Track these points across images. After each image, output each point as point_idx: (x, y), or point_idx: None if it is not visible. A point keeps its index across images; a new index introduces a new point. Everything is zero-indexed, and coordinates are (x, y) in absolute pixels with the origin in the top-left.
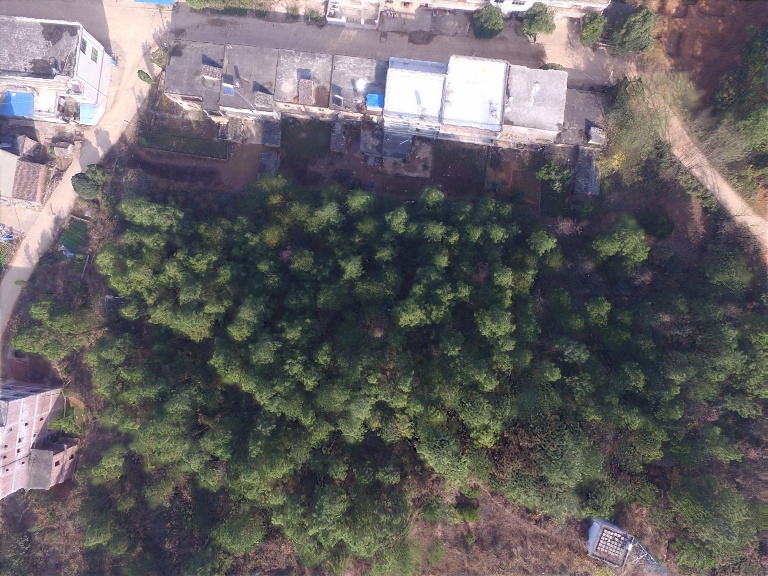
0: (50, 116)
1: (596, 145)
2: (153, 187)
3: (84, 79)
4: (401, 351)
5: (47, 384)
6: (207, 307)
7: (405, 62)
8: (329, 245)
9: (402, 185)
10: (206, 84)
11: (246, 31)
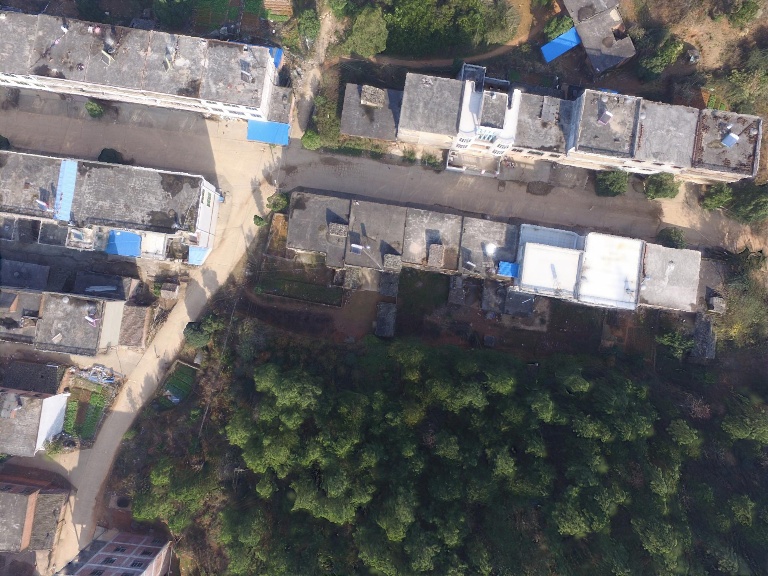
0: (158, 258)
1: (716, 313)
2: (271, 340)
3: (201, 228)
4: (557, 555)
5: (152, 536)
6: (355, 499)
7: (536, 228)
8: (472, 429)
9: (519, 339)
10: (330, 240)
11: (360, 172)
